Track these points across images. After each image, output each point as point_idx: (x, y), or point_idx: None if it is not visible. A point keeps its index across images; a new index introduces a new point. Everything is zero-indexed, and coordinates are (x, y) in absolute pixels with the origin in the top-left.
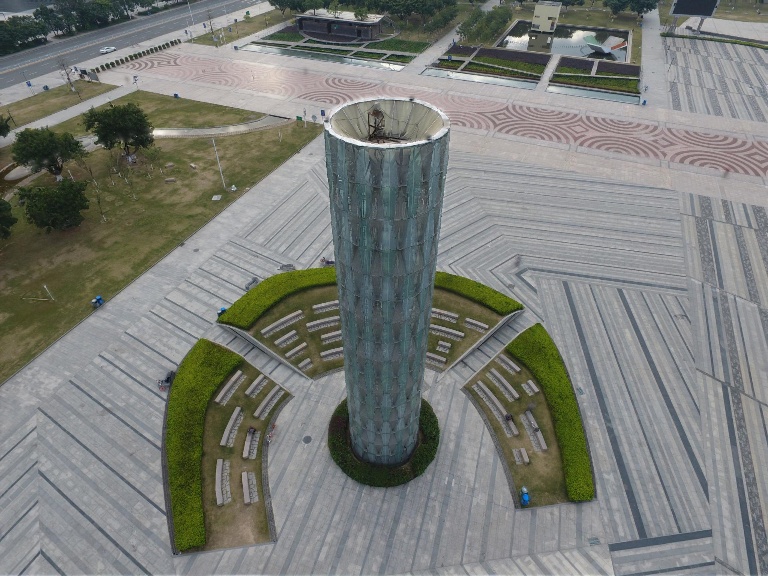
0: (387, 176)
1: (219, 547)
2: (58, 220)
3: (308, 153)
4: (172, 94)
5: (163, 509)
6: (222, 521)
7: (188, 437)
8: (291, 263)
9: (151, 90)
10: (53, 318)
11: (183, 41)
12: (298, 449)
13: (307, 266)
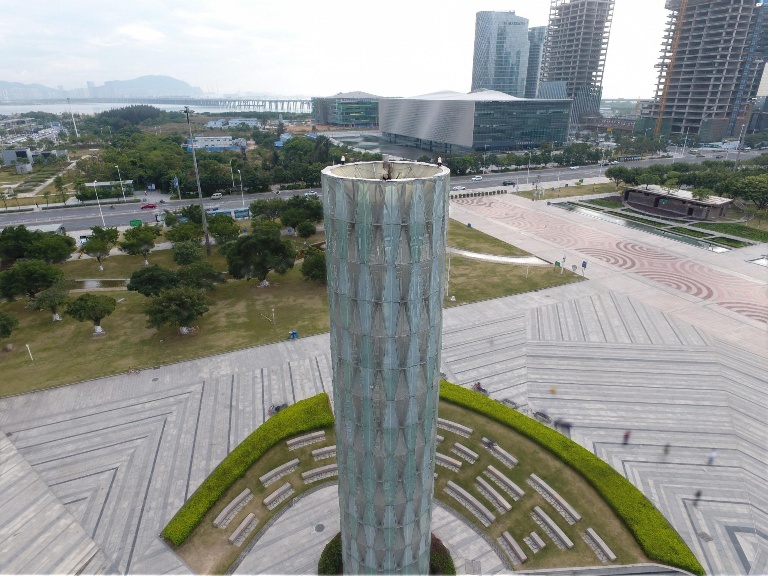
0: (342, 209)
1: (183, 558)
2: (316, 275)
3: (545, 294)
4: (467, 223)
5: (188, 497)
6: (204, 539)
7: (246, 455)
8: (447, 374)
9: (455, 218)
10: (263, 333)
11: (509, 192)
12: (305, 530)
13: (459, 383)
